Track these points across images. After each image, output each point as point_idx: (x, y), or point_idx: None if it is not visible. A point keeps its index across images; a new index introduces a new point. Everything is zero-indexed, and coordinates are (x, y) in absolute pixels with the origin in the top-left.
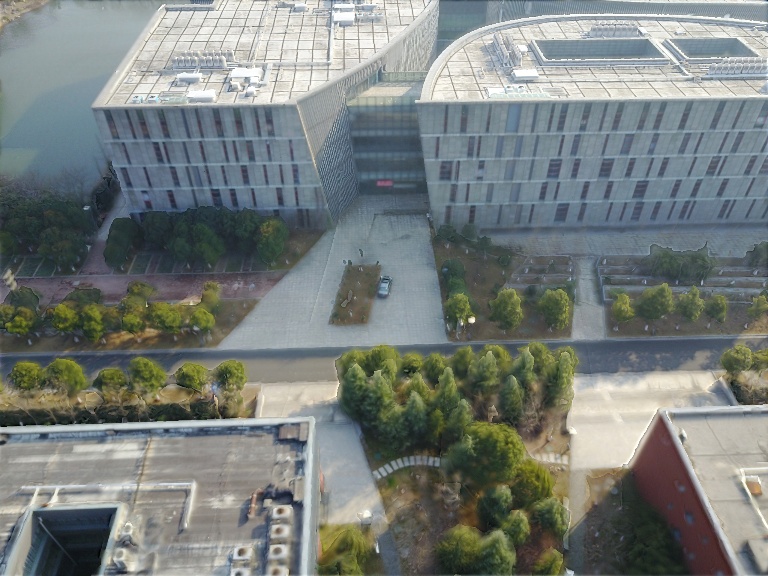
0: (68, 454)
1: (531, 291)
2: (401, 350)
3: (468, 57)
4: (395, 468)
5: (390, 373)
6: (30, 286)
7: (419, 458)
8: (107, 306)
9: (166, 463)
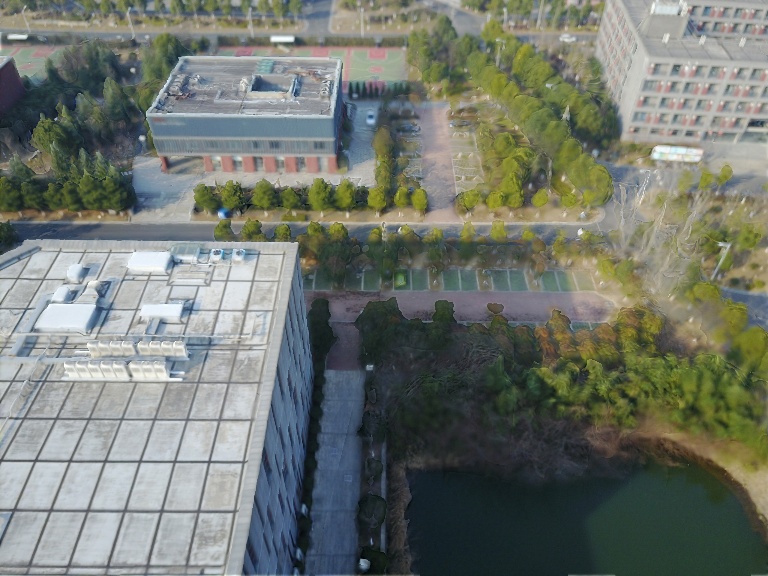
0: (280, 112)
1: None
2: None
3: None
4: None
5: None
6: (409, 309)
7: None
8: (324, 287)
9: (229, 107)
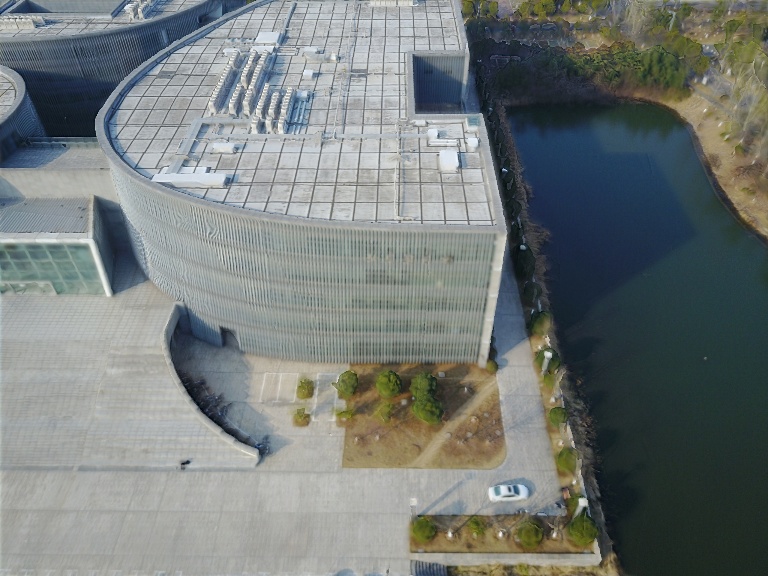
0: None
1: None
2: None
3: (180, 6)
4: None
5: None
6: None
7: None
8: None
9: None
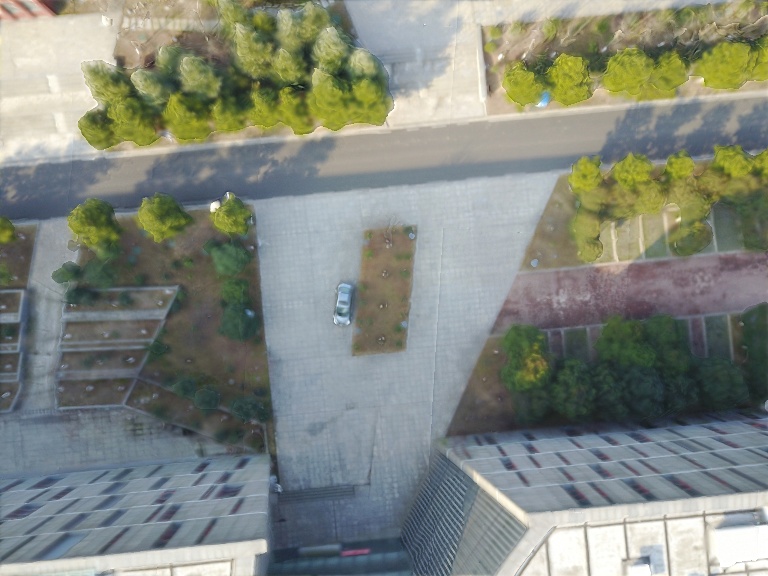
0: None
1: (127, 295)
2: (316, 182)
3: None
4: (316, 0)
5: (320, 69)
6: None
7: (289, 6)
8: (733, 246)
9: None
